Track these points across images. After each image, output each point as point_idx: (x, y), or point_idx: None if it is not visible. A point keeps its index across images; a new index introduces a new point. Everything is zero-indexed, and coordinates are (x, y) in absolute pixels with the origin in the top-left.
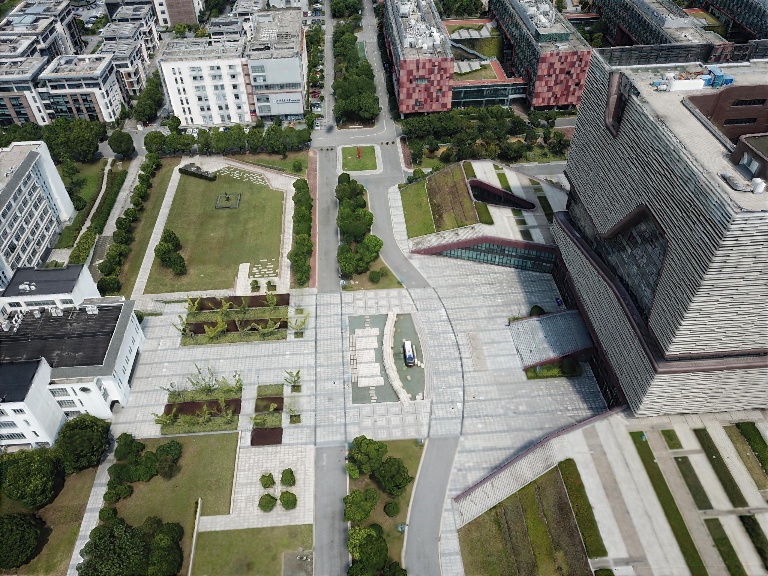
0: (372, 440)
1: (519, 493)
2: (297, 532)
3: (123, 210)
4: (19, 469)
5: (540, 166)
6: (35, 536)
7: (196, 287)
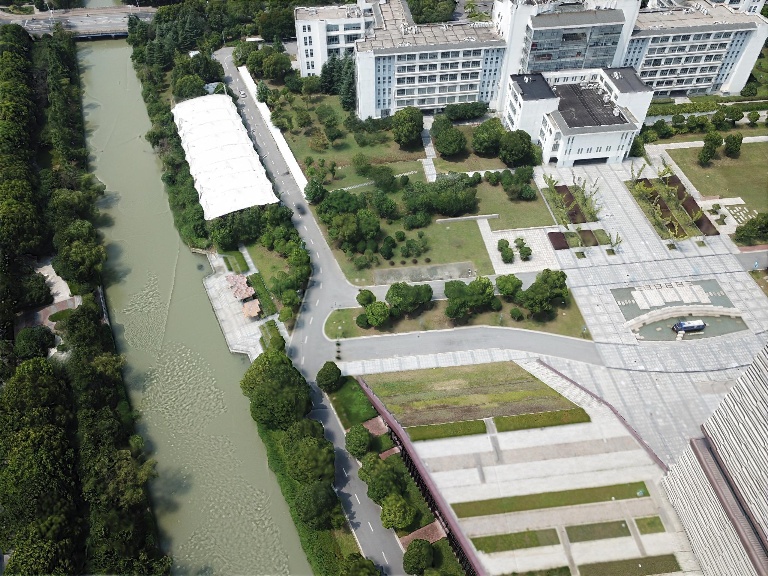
0: (562, 279)
1: (549, 388)
2: (488, 266)
3: (761, 117)
4: (487, 124)
5: None
6: (454, 149)
7: (691, 175)
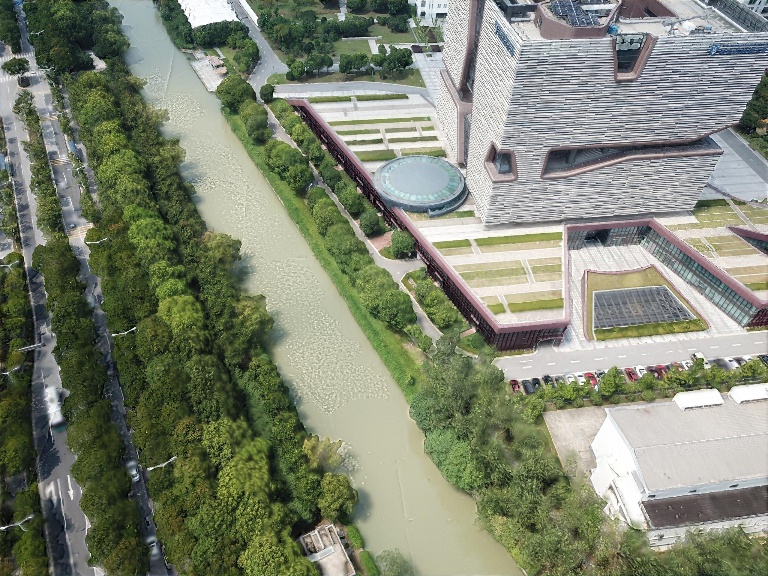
0: (409, 52)
1: None
2: None
3: None
4: None
5: (744, 146)
6: (358, 4)
7: None
